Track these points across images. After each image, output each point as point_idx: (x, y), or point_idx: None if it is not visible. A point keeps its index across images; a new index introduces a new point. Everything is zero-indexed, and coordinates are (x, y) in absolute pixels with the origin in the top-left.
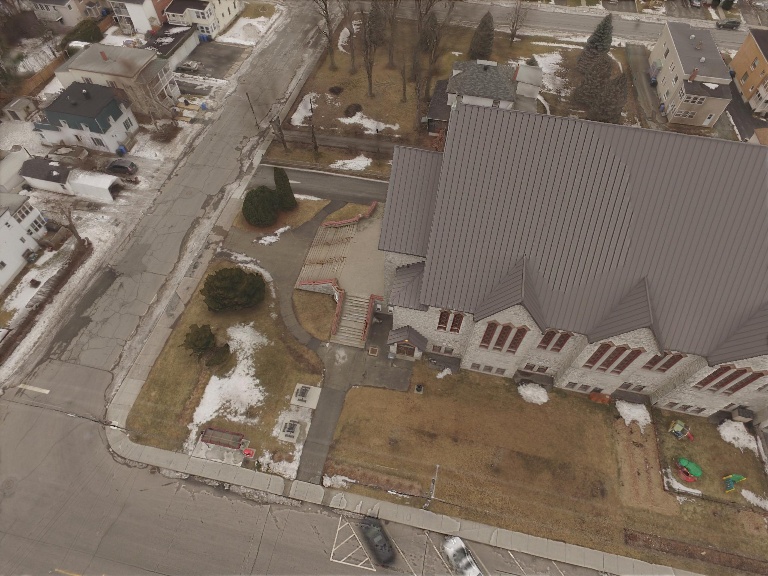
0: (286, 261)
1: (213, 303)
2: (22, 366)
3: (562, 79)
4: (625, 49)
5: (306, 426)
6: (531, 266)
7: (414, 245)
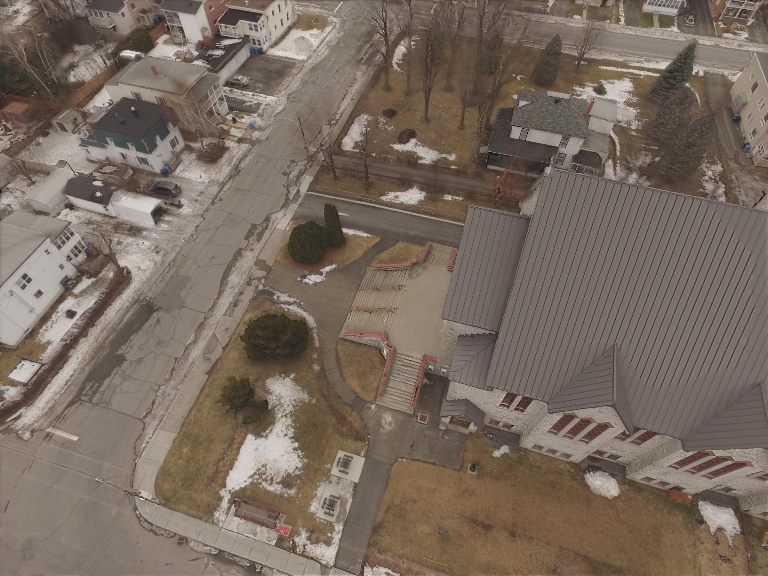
0: (331, 305)
1: (253, 351)
2: (52, 407)
3: (633, 109)
4: (703, 78)
5: (347, 503)
6: (622, 357)
7: (483, 317)
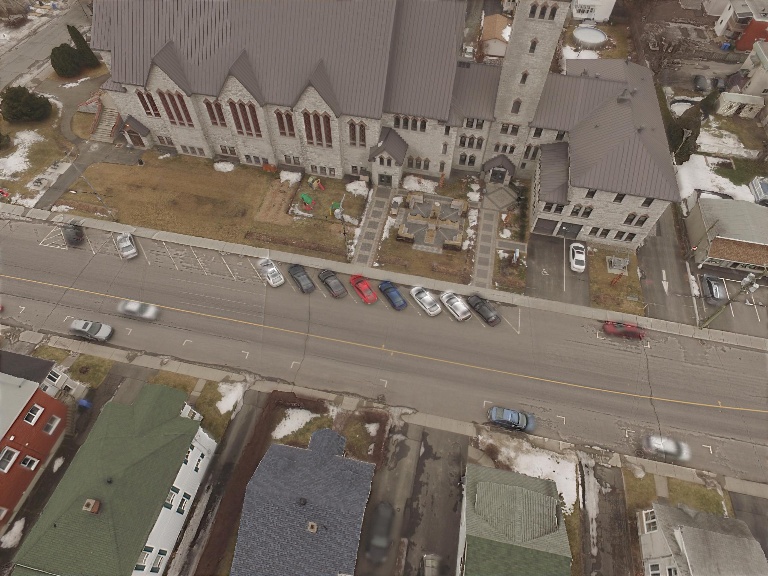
0: (78, 97)
1: (7, 114)
2: None
3: None
4: None
5: (52, 182)
6: (175, 47)
7: None
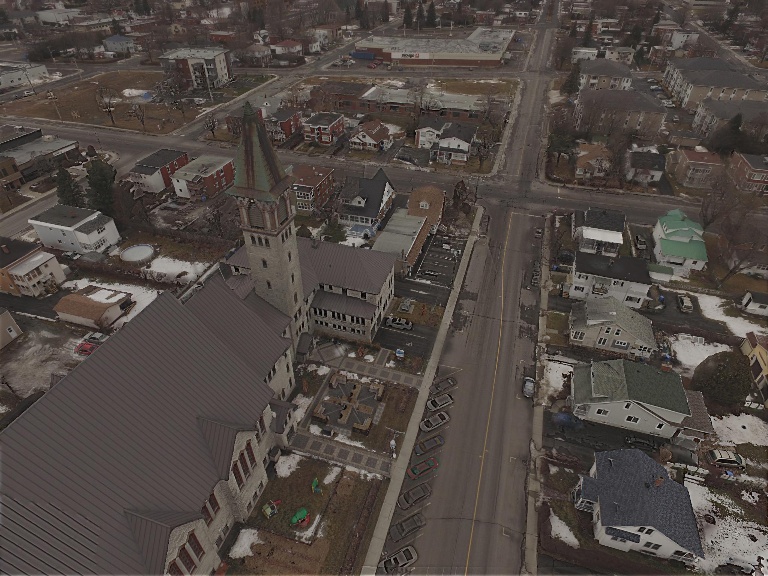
0: None
1: None
2: None
3: None
4: None
5: None
6: None
7: None
